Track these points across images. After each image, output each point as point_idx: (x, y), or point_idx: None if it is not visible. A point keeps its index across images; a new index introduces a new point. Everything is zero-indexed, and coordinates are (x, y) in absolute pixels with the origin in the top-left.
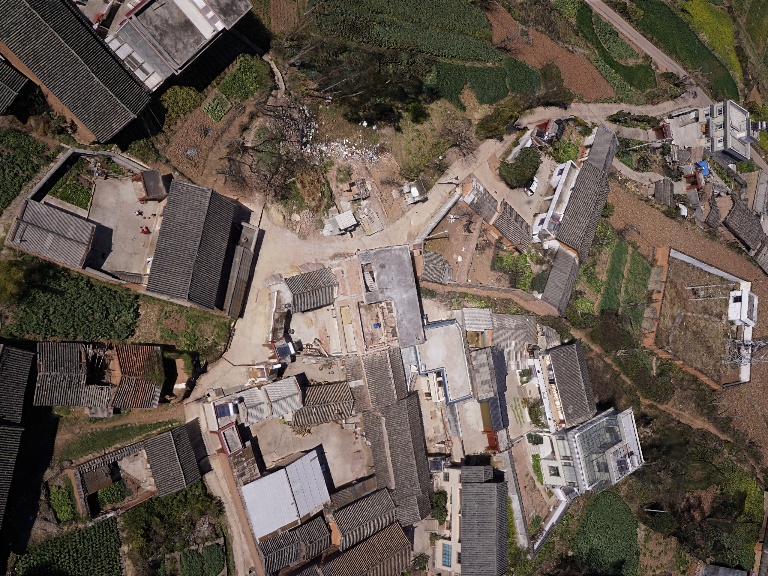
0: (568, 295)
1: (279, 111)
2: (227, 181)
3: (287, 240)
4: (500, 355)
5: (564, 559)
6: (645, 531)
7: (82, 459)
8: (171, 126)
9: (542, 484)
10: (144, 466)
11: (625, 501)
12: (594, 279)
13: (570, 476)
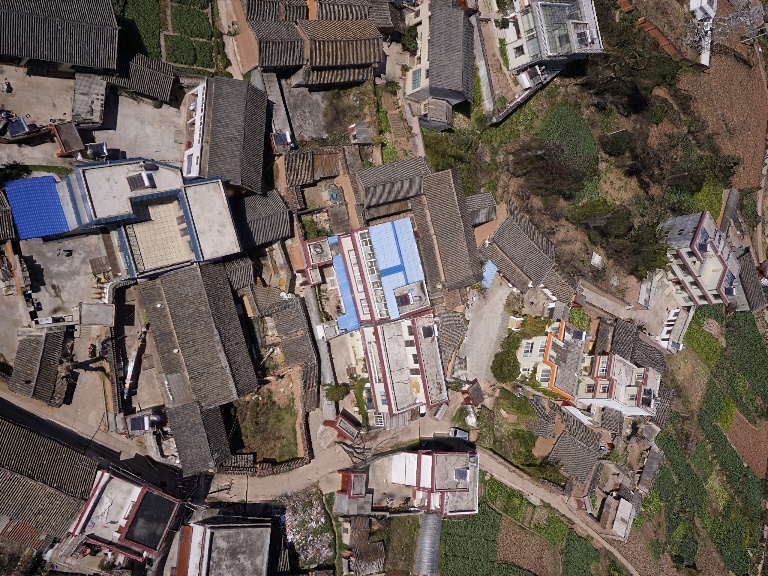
0: None
1: None
2: None
3: None
4: None
5: None
6: (606, 162)
7: None
8: None
9: (508, 70)
10: None
11: (587, 125)
12: None
13: (534, 50)
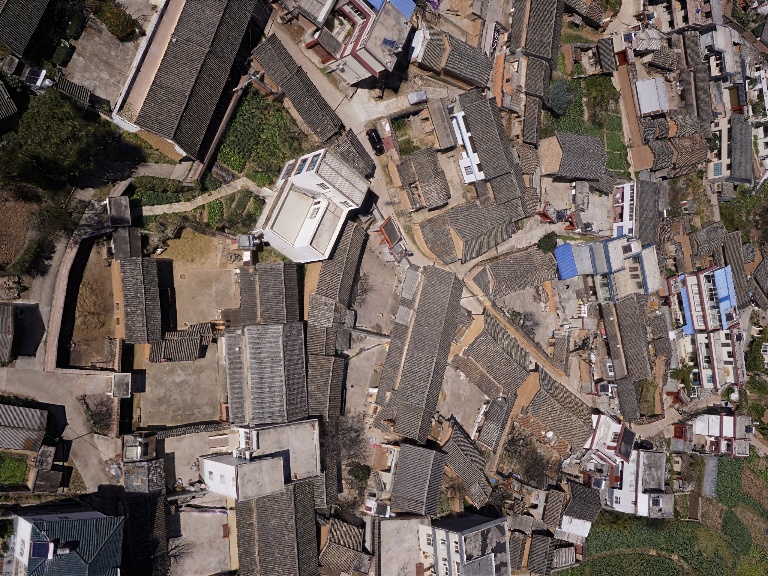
0: None
1: None
2: None
3: None
4: (743, 62)
5: (766, 210)
6: None
7: None
8: None
9: (757, 156)
10: (588, 62)
11: None
12: None
13: None
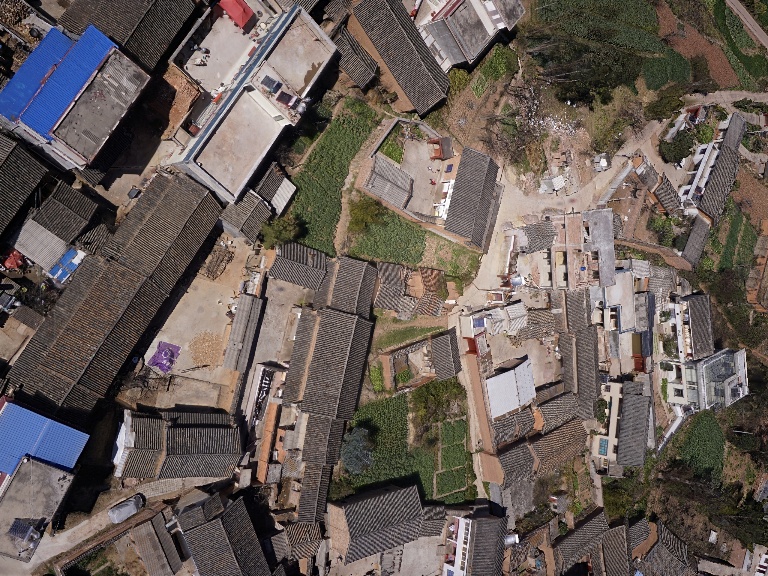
0: (700, 254)
1: (518, 91)
2: (483, 146)
3: (516, 195)
4: (652, 298)
5: (673, 461)
6: (728, 448)
7: (388, 349)
8: (451, 101)
9: (666, 402)
10: (422, 358)
11: (718, 423)
12: (717, 242)
13: (692, 397)
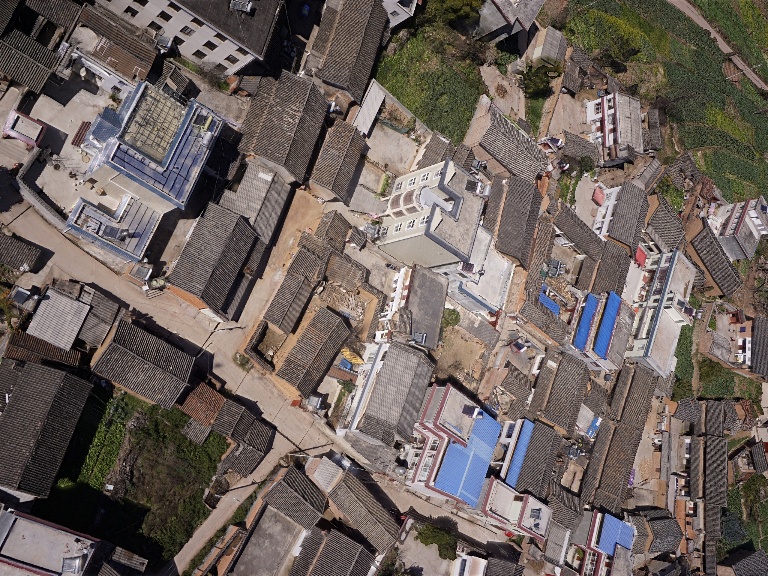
0: None
1: (763, 267)
2: None
3: None
4: None
5: None
6: None
7: None
8: None
9: None
10: (741, 460)
11: None
12: None
13: None
